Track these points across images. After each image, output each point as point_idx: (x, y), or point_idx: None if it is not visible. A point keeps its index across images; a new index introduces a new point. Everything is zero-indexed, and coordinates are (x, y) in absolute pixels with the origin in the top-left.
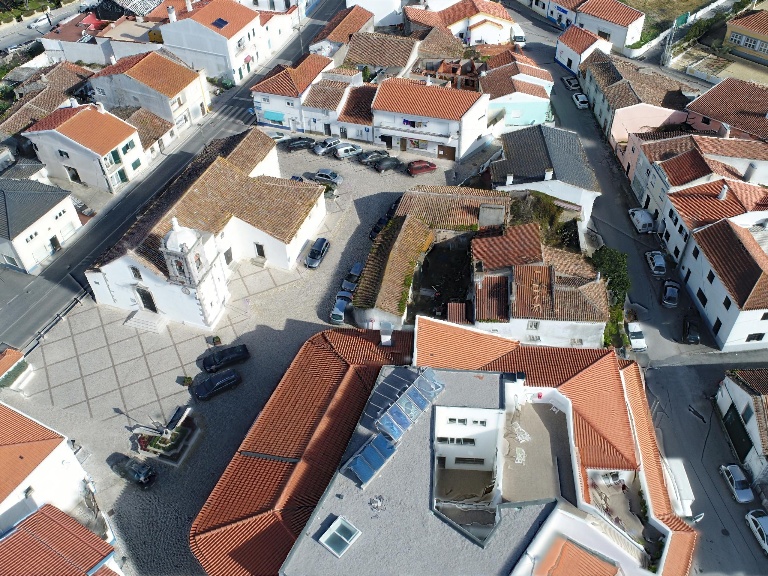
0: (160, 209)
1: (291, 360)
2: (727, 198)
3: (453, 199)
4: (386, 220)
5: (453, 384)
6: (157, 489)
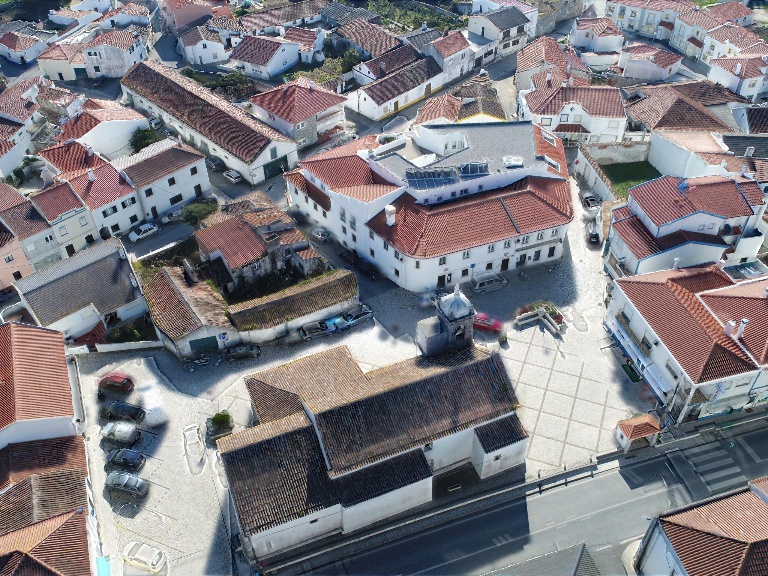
0: (421, 415)
1: (424, 314)
2: (94, 176)
3: (190, 297)
4: (233, 349)
5: (400, 171)
6: (566, 300)
